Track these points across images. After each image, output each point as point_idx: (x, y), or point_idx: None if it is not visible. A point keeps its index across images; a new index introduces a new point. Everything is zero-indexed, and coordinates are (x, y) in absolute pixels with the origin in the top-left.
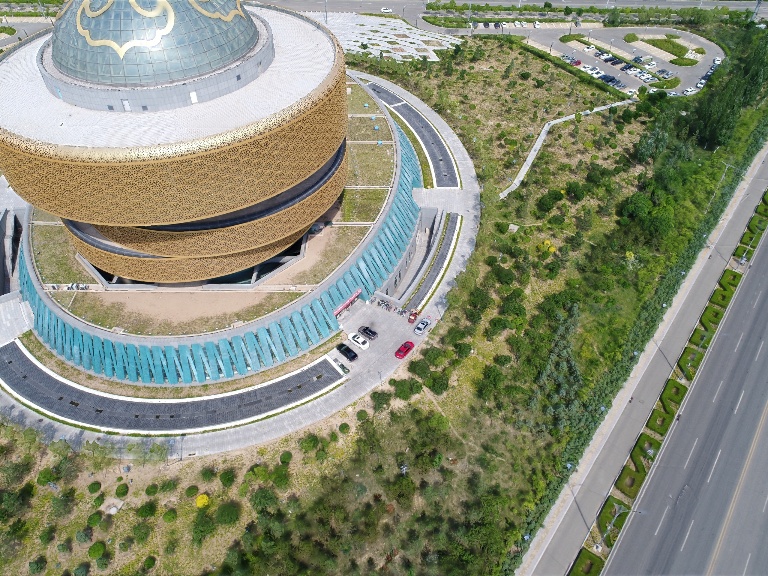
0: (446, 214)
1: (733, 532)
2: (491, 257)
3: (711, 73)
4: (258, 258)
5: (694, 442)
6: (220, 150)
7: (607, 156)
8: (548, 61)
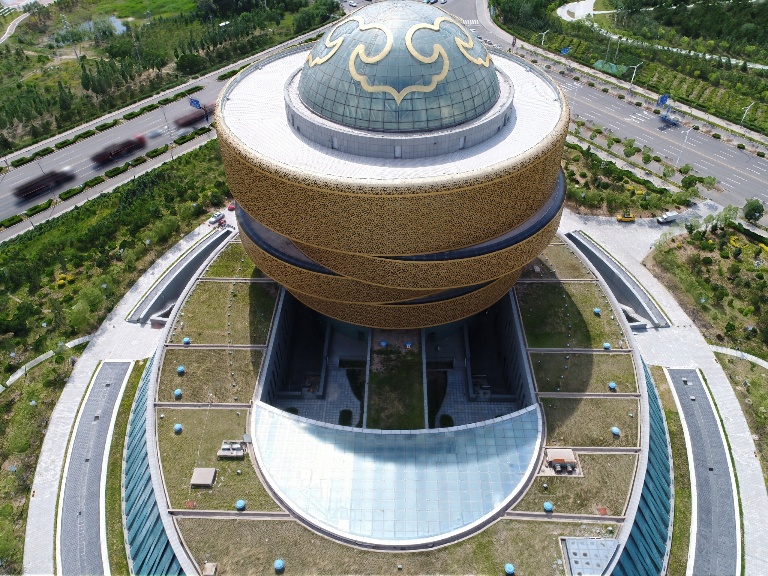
0: None
1: (104, 149)
2: None
3: None
4: None
5: (84, 175)
6: None
7: None
8: None
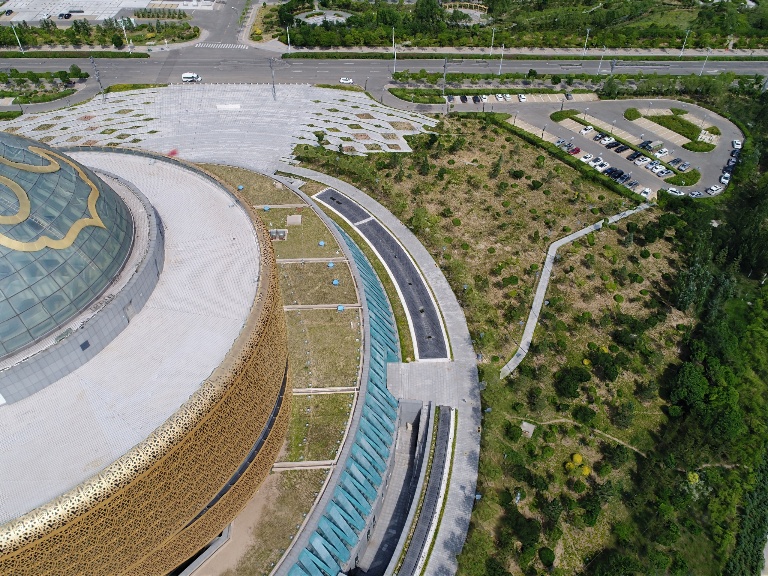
0: (434, 409)
1: None
2: (504, 495)
3: (734, 162)
4: None
5: None
6: (21, 550)
7: (635, 299)
8: (541, 148)
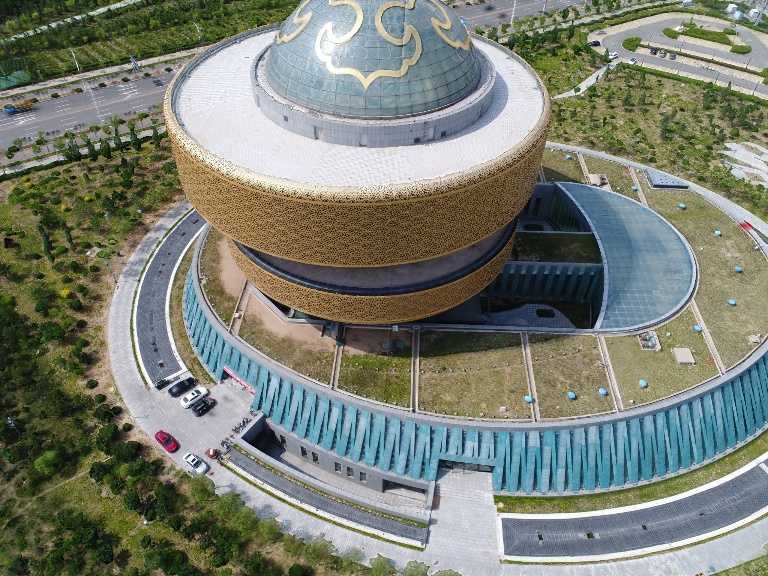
0: (422, 521)
1: None
2: (298, 569)
3: None
4: None
5: None
6: None
7: None
8: None
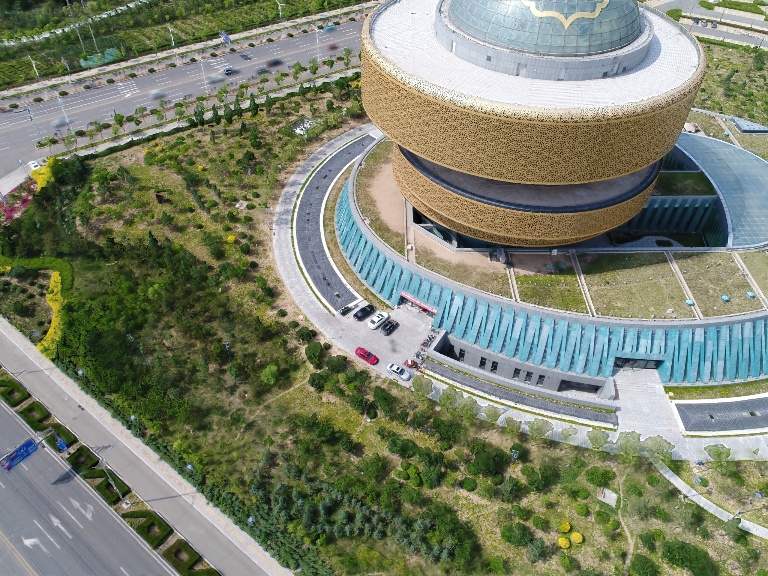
0: (610, 408)
1: None
2: (519, 447)
3: None
4: (419, 205)
5: None
6: (381, 72)
7: None
8: None
